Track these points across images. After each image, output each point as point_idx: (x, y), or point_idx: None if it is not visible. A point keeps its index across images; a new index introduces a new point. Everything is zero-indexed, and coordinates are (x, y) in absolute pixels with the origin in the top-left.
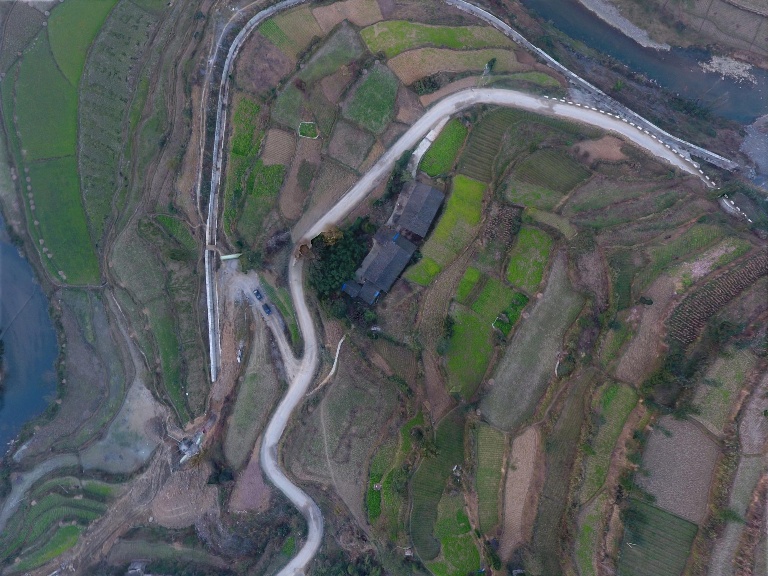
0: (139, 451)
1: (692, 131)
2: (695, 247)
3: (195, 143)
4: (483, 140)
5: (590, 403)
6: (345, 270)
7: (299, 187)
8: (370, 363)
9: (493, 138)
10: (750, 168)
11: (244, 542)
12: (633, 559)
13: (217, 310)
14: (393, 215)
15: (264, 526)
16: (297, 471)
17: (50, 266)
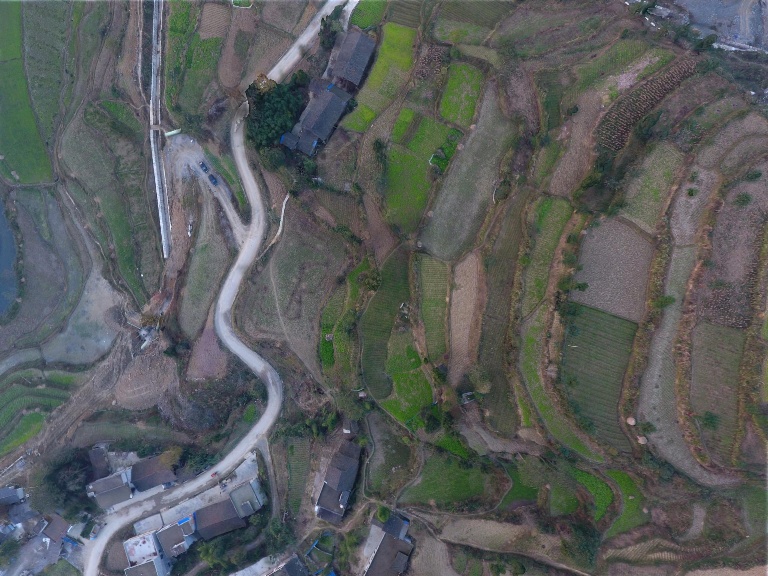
0: (100, 341)
1: None
2: (620, 62)
3: (133, 25)
4: None
5: (526, 219)
6: (280, 118)
7: (236, 56)
8: (315, 217)
9: None
10: (683, 15)
11: (206, 413)
12: (576, 361)
13: (165, 187)
14: (327, 69)
15: (224, 395)
16: (250, 330)
17: (3, 167)
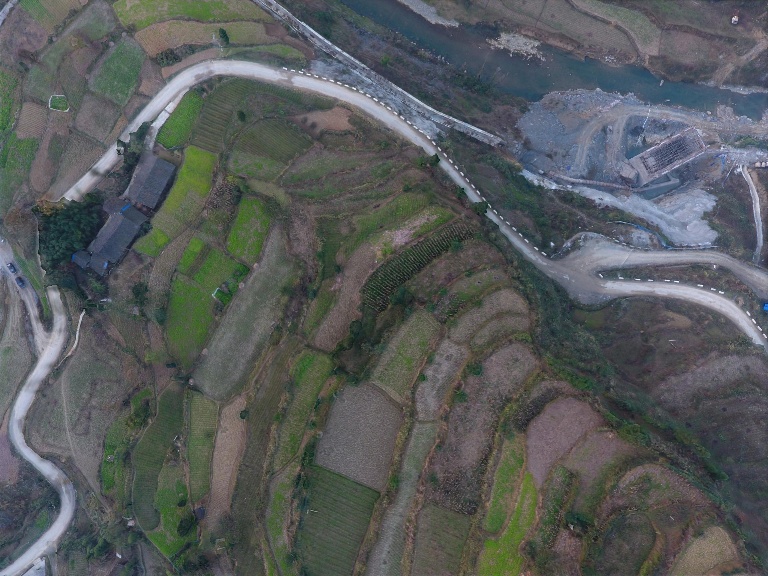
0: None
1: (466, 107)
2: (400, 216)
3: None
4: (215, 111)
5: (288, 371)
6: (66, 240)
7: (49, 160)
8: (108, 335)
9: (225, 109)
10: (517, 143)
11: None
12: (314, 526)
13: None
14: (129, 187)
15: (18, 499)
16: (37, 443)
17: None
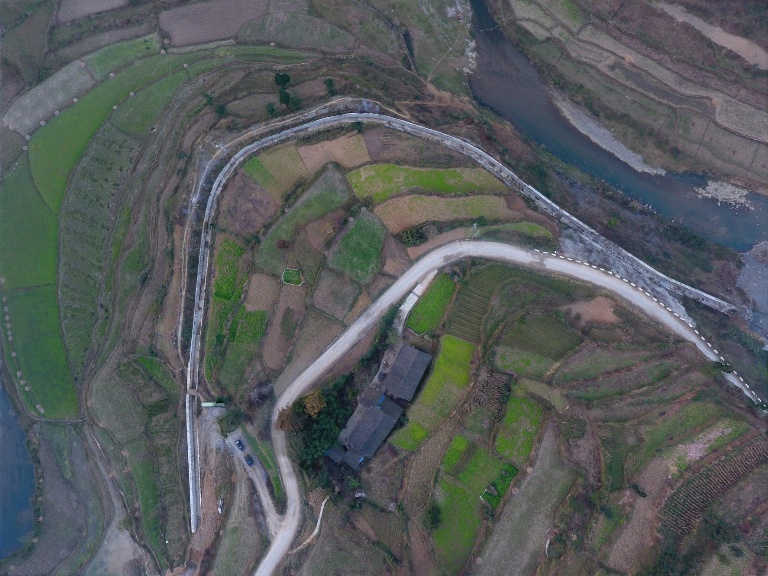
0: None
1: (688, 266)
2: (690, 426)
3: (176, 285)
4: (472, 299)
5: None
6: (328, 440)
7: (283, 336)
8: (354, 526)
9: (482, 297)
10: (747, 308)
11: None
12: None
13: (198, 458)
14: (379, 373)
15: None
16: None
17: (28, 399)
